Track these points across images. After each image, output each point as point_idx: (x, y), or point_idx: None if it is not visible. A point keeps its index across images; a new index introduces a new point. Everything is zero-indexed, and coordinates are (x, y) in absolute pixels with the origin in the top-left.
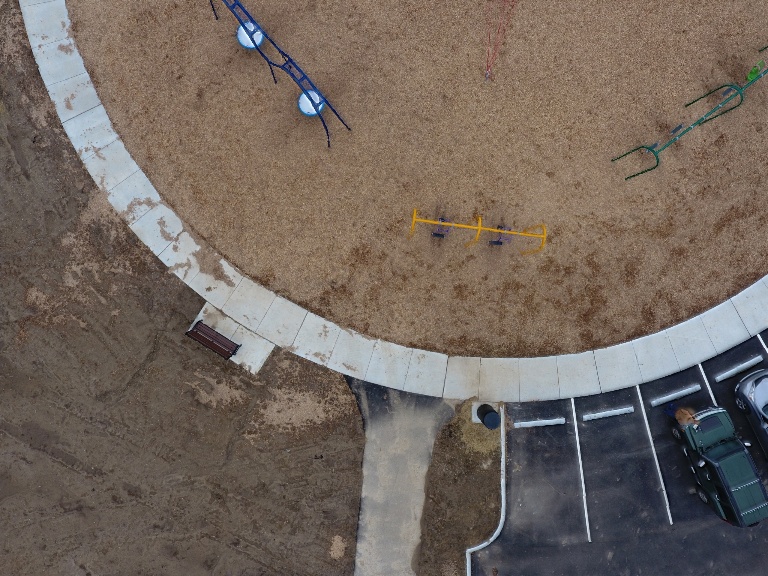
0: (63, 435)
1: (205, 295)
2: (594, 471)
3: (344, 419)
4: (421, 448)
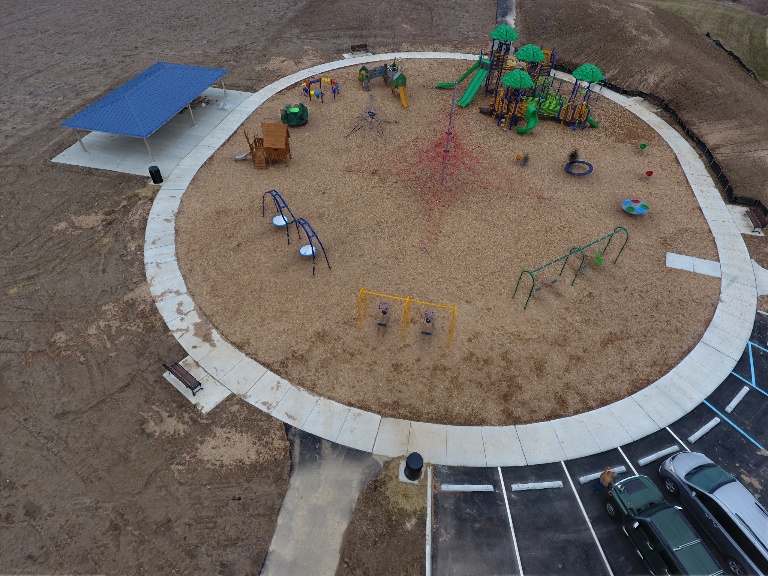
0: (3, 445)
1: (190, 351)
2: (531, 551)
3: (273, 463)
4: (344, 501)
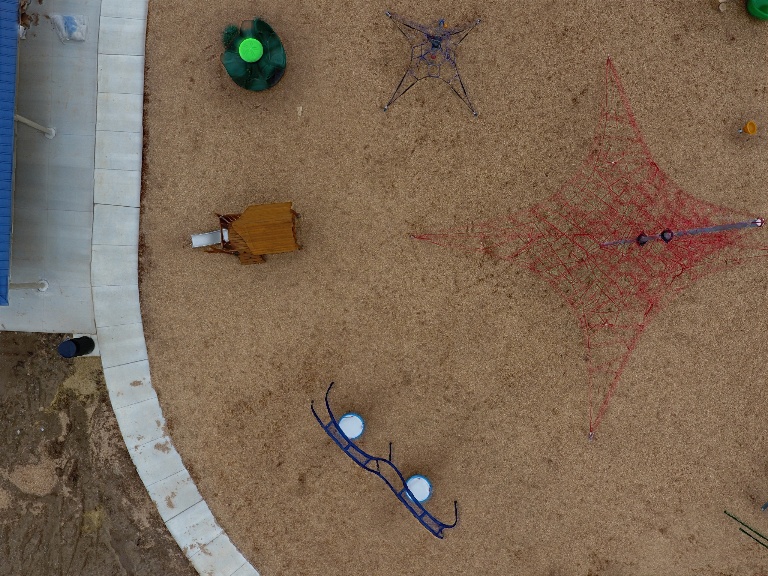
0: None
1: None
2: None
3: None
4: None
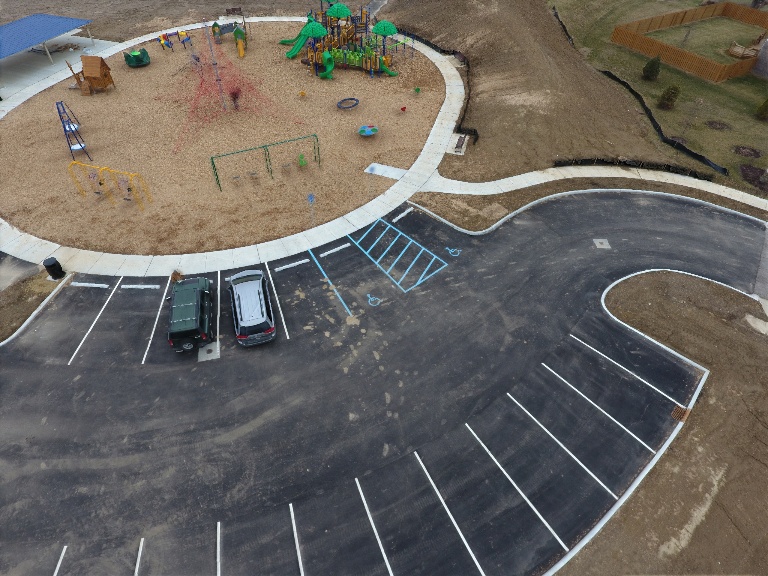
0: None
1: None
2: (107, 319)
3: None
4: None
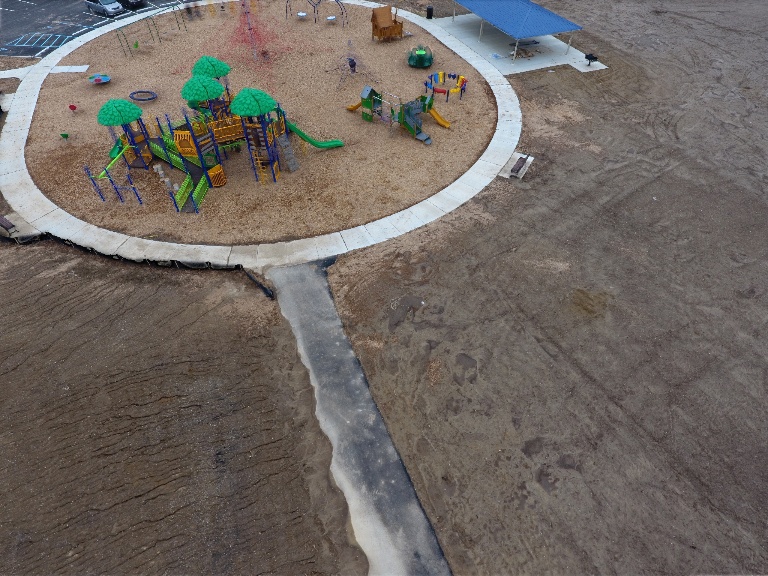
0: None
1: None
2: None
3: None
4: None
